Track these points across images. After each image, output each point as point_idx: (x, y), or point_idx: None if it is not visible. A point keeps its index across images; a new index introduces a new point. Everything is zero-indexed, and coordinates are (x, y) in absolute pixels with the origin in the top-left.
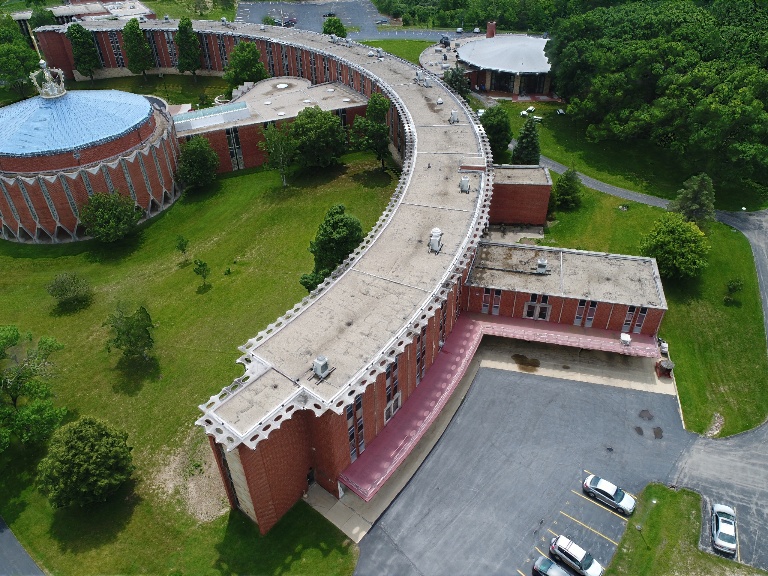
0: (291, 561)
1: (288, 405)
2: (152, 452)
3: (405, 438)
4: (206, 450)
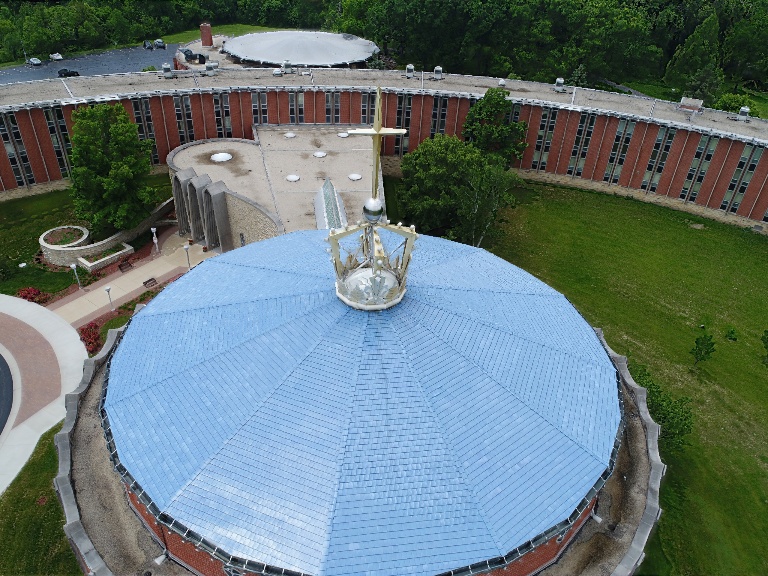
0: None
1: None
2: None
3: None
4: None
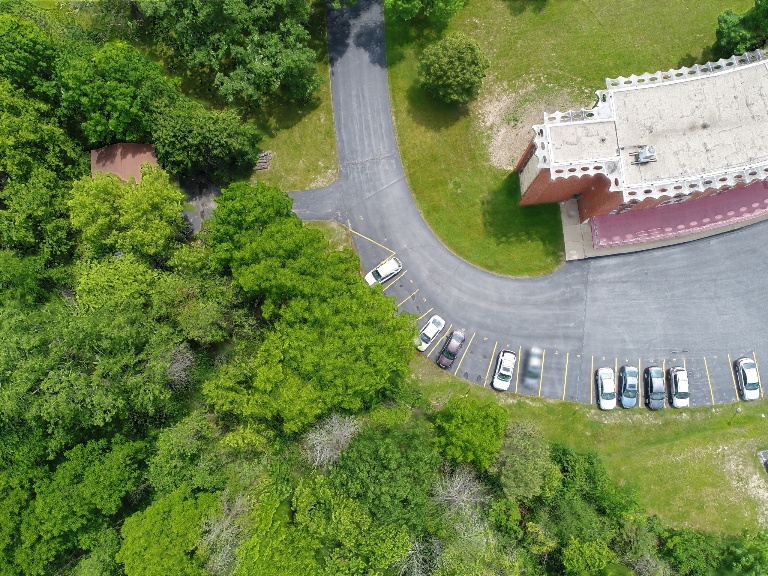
0: (522, 236)
1: (599, 164)
2: (495, 81)
3: (660, 228)
4: (529, 112)
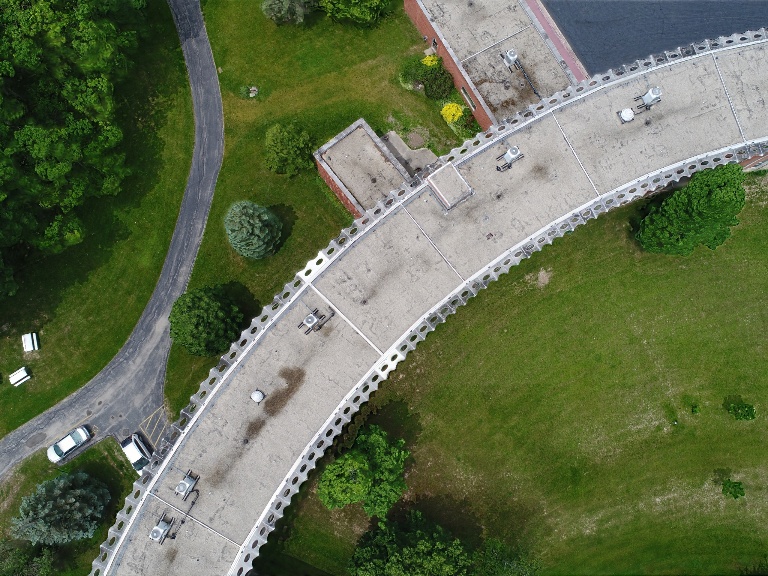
0: None
1: None
2: None
3: None
4: None
